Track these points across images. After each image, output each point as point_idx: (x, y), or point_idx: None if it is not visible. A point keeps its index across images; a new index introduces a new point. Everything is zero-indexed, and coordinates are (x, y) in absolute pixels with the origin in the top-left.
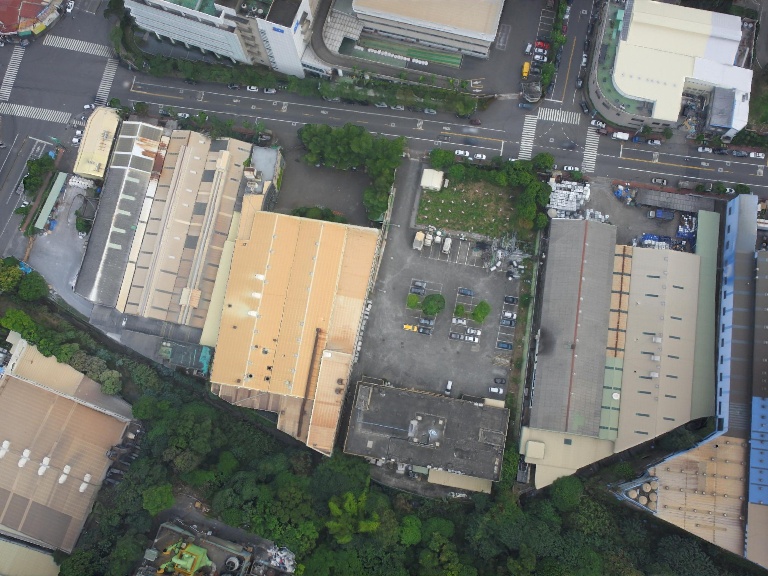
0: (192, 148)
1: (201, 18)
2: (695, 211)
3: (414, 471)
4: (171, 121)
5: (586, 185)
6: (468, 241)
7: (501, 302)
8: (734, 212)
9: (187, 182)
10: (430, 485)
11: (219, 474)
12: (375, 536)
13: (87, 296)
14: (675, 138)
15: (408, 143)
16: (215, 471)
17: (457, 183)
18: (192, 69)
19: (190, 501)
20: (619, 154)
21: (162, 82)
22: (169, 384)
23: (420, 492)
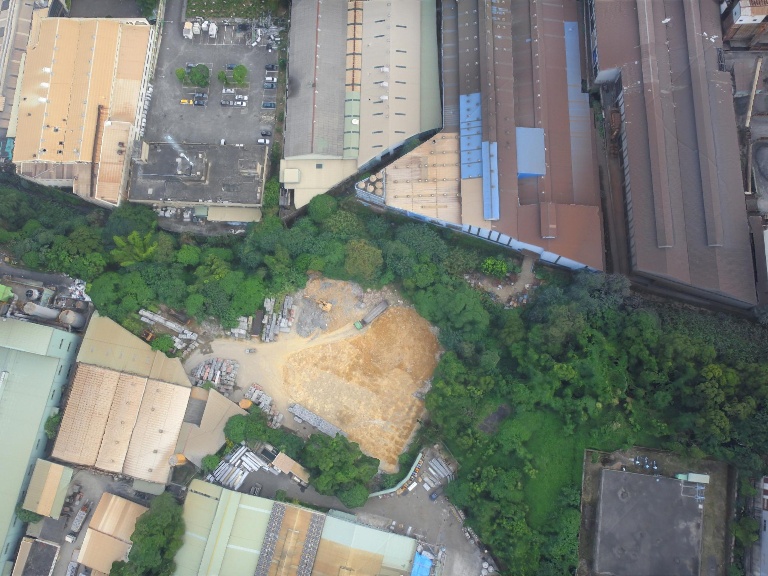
0: None
1: None
2: None
3: (196, 214)
4: None
5: None
6: (232, 25)
7: (263, 71)
8: None
9: None
10: (213, 227)
11: (23, 233)
12: (154, 257)
13: None
14: None
15: None
16: (20, 232)
17: None
18: None
19: (0, 258)
20: None
21: None
22: None
23: (205, 234)
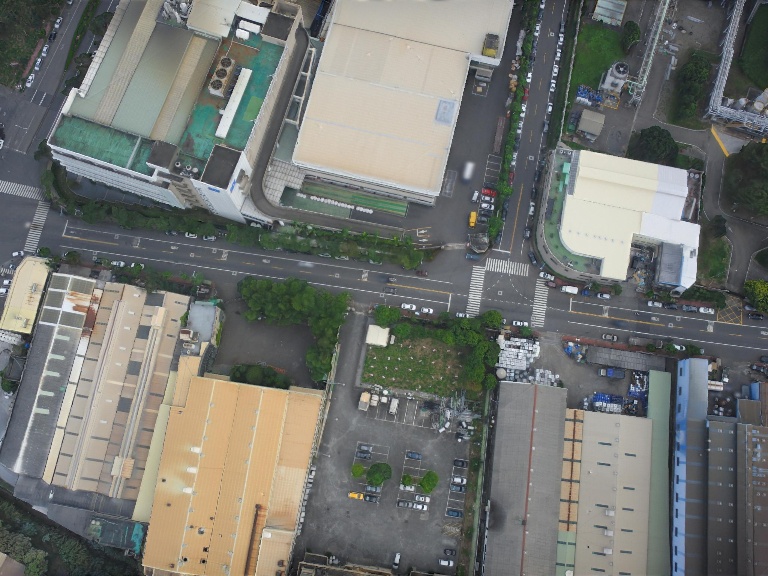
0: (126, 302)
1: (133, 175)
2: (646, 370)
3: None
4: (105, 271)
5: (535, 343)
6: (416, 400)
7: (450, 466)
8: (685, 375)
9: (120, 339)
10: None
11: None
12: None
13: (11, 467)
14: (625, 291)
15: (353, 295)
16: None
17: (404, 339)
18: (127, 217)
19: None
20: (569, 308)
21: (96, 227)
22: (100, 561)
23: None
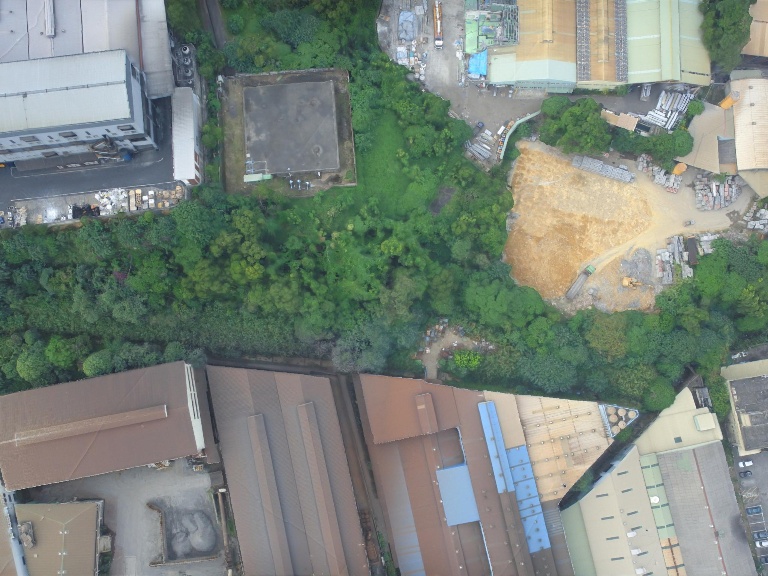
0: None
1: None
2: None
3: None
4: None
5: None
6: None
7: None
8: None
9: None
10: (767, 355)
11: None
12: None
13: None
14: None
15: None
16: None
17: None
18: None
19: None
20: None
21: None
22: None
23: None
